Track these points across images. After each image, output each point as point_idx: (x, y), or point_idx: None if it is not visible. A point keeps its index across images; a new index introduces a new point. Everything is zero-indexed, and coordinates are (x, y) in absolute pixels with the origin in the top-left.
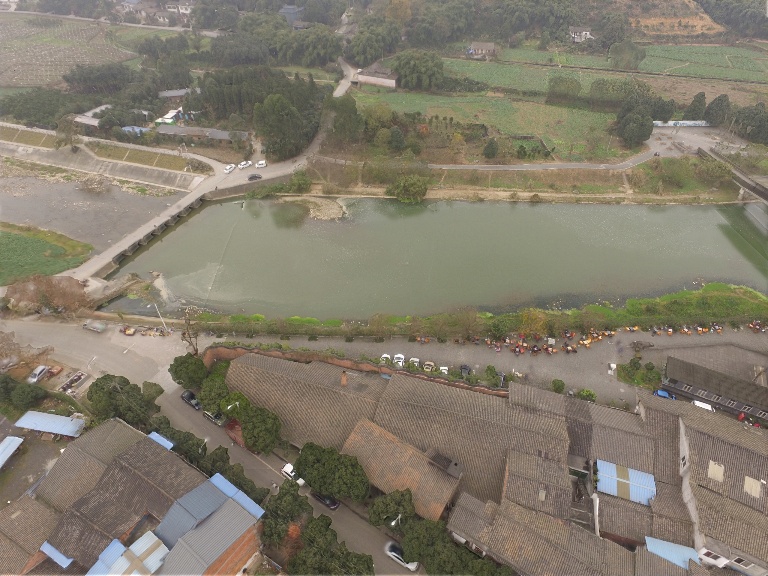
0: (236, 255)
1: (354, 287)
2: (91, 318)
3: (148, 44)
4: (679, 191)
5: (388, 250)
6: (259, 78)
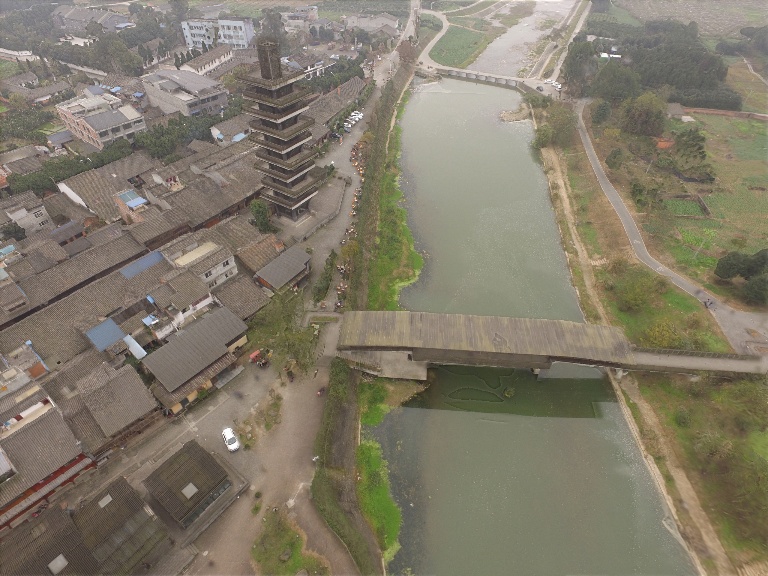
0: (458, 95)
1: (428, 123)
2: (405, 70)
3: (757, 29)
4: (611, 305)
5: (466, 133)
6: (698, 62)
